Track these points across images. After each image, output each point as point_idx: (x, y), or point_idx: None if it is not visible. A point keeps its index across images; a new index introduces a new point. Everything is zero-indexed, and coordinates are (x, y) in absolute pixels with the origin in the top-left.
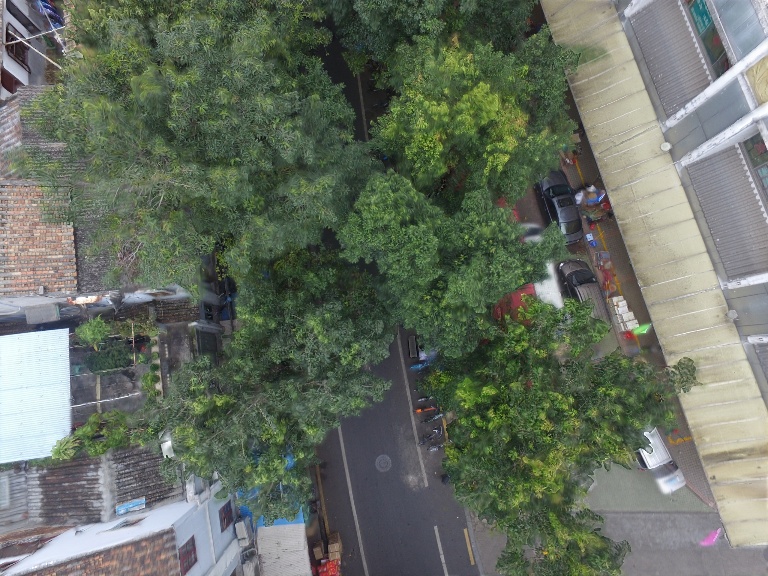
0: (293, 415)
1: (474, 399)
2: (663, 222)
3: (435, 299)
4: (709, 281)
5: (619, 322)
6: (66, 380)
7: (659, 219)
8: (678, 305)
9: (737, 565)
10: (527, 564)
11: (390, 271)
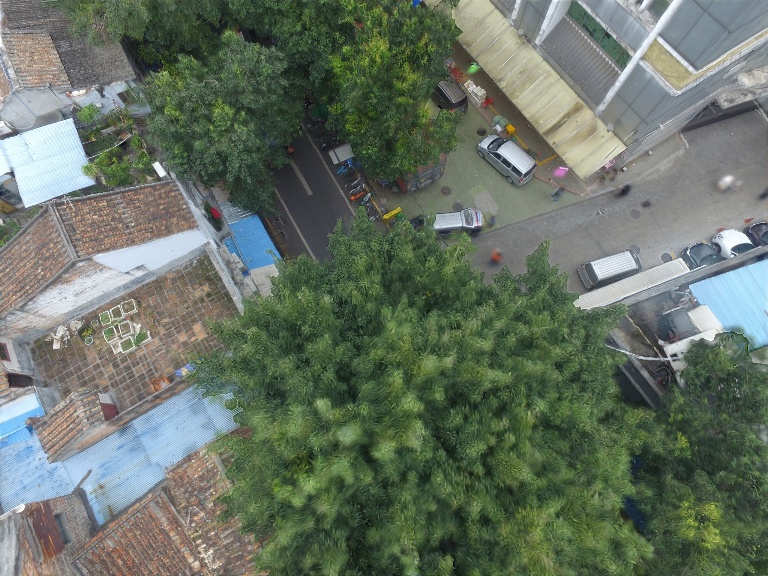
0: (229, 88)
1: (342, 63)
2: (464, 3)
3: (305, 31)
4: (504, 25)
5: (474, 98)
6: (79, 145)
7: (461, 2)
8: (492, 49)
9: (615, 228)
10: (409, 148)
11: (266, 5)
